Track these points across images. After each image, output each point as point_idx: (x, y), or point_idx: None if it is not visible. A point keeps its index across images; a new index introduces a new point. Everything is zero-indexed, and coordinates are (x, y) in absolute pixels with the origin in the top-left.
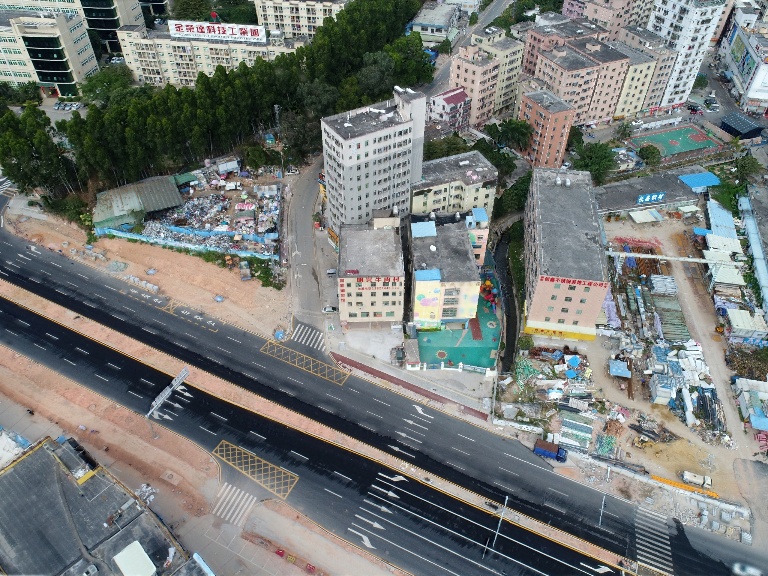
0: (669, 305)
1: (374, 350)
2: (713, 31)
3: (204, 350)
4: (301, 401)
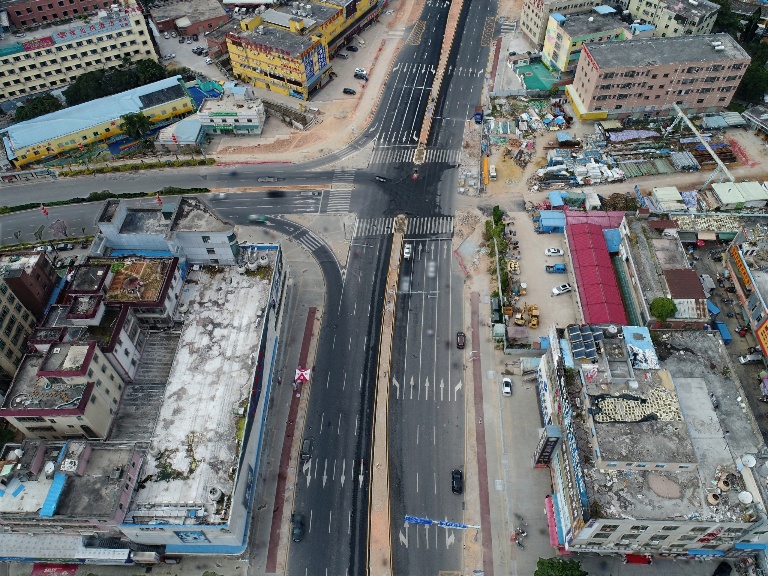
0: (661, 166)
1: (513, 49)
2: None
3: (475, 2)
4: (462, 36)
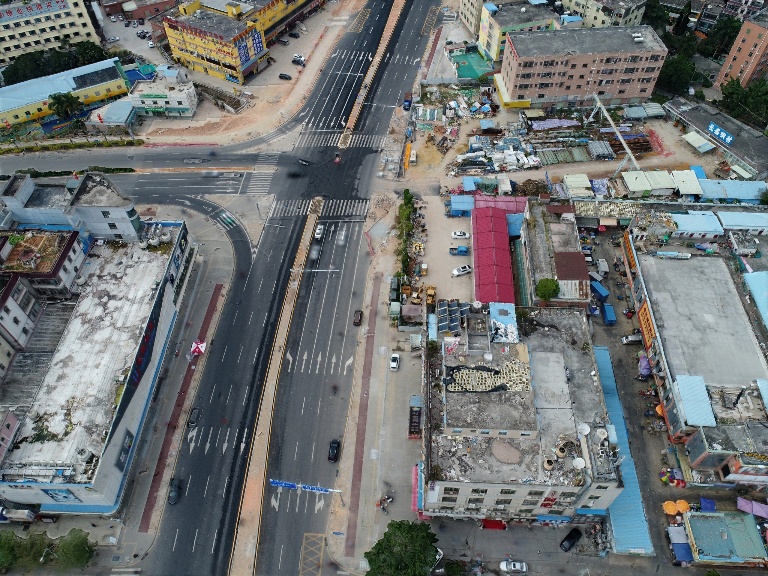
0: (578, 154)
1: (452, 38)
2: None
3: None
4: (404, 24)
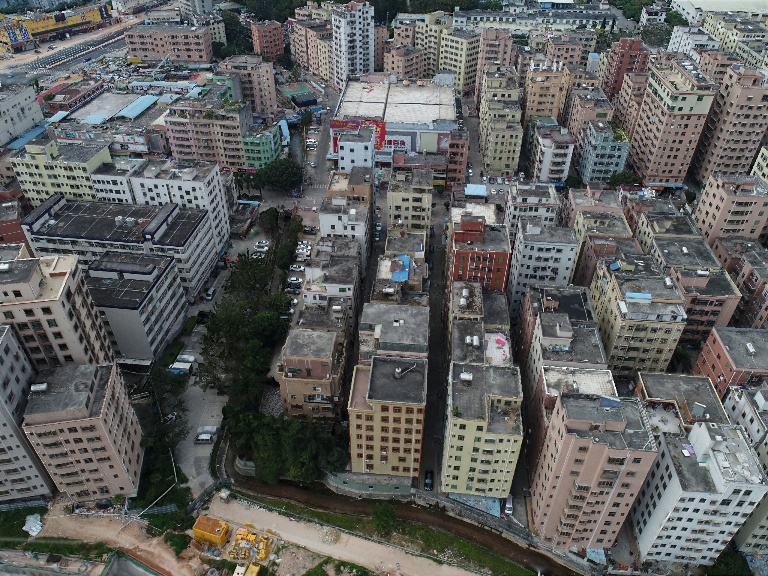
0: None
1: None
2: (344, 39)
3: None
4: None
